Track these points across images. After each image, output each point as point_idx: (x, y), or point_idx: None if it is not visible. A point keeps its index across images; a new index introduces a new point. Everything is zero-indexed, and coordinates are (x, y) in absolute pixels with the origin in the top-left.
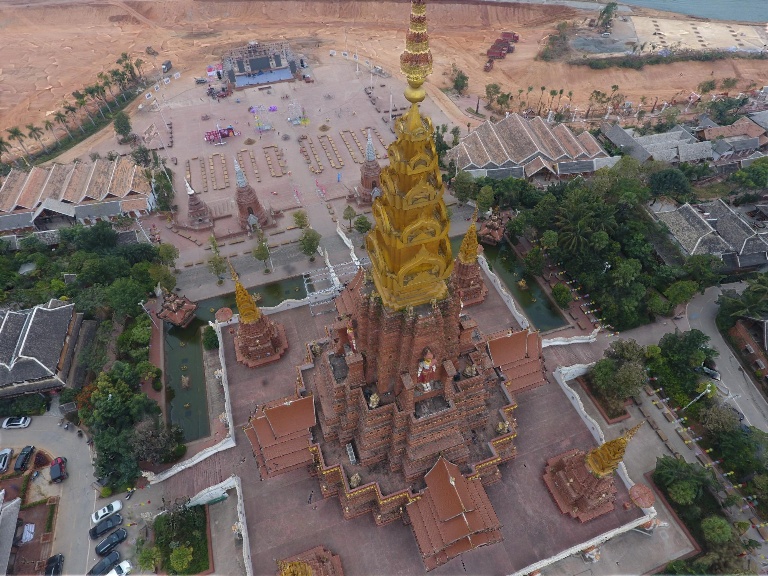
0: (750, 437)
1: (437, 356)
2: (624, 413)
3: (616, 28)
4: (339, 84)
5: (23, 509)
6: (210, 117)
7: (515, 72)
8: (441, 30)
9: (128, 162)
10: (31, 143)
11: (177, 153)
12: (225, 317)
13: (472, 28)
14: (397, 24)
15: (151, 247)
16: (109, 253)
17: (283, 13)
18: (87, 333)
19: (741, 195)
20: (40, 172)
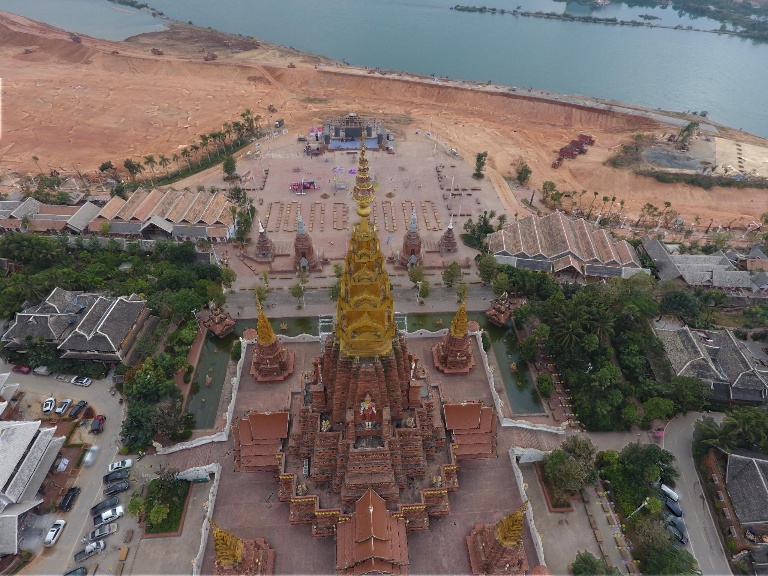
0: (674, 557)
1: (378, 401)
2: (568, 505)
3: (695, 146)
4: (415, 159)
5: (65, 447)
6: (300, 170)
7: (581, 173)
8: (524, 124)
9: (223, 197)
10: (159, 169)
11: (265, 195)
12: (250, 336)
13: (553, 126)
14: (485, 113)
15: (218, 268)
16: (186, 267)
17: (388, 91)
18: (150, 325)
19: (761, 330)
20: (158, 194)
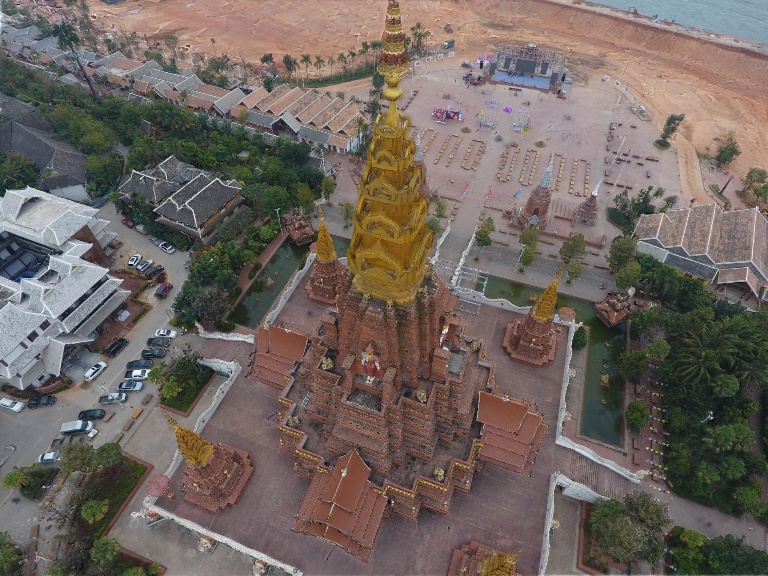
0: None
1: (384, 357)
2: (604, 571)
3: None
4: (589, 110)
5: (132, 301)
6: (451, 97)
7: None
8: (756, 93)
9: (358, 108)
10: (313, 70)
11: None
12: (315, 249)
13: None
14: (705, 71)
15: None
16: (295, 168)
17: (588, 27)
18: (240, 214)
19: None
20: (299, 92)
